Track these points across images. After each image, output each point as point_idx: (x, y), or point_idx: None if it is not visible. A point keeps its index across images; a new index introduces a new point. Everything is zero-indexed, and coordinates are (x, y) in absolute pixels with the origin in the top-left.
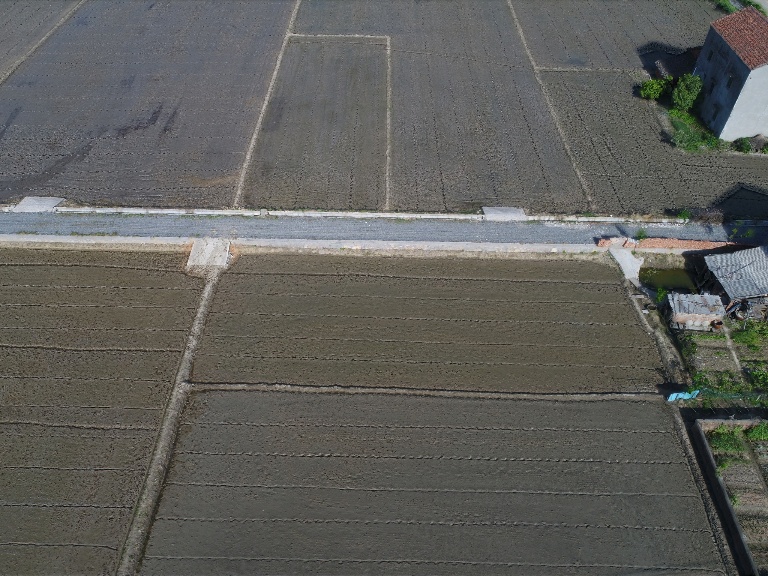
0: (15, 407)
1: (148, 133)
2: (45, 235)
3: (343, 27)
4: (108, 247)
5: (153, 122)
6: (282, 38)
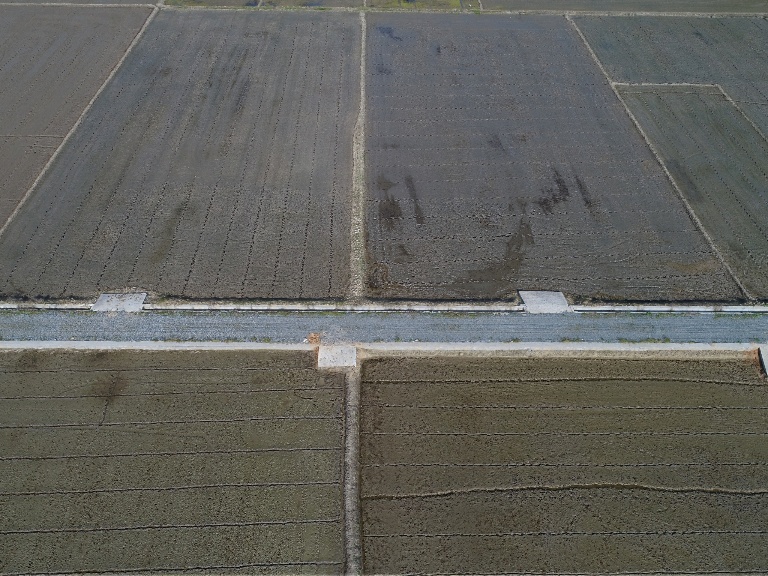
0: (745, 574)
1: (574, 207)
2: (592, 343)
3: (659, 74)
4: (663, 355)
5: (566, 193)
6: (609, 88)
